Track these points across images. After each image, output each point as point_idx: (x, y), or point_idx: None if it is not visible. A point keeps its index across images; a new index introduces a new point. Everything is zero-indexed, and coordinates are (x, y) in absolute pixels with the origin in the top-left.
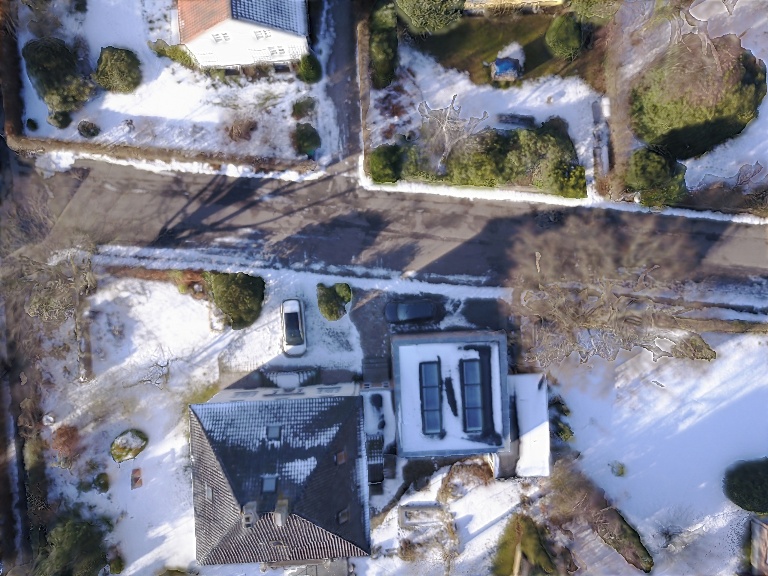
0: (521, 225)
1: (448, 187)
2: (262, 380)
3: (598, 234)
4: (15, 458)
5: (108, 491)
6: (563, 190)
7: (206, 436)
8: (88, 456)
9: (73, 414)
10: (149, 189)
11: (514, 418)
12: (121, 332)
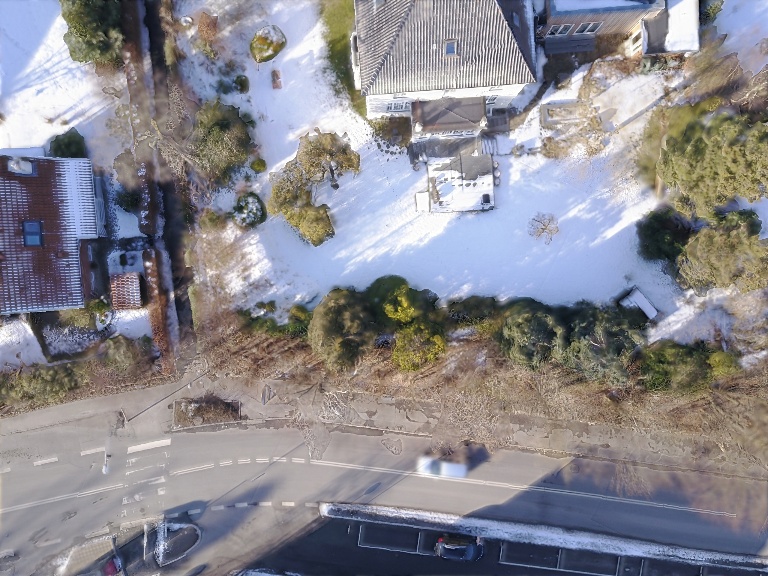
0: None
1: None
2: None
3: None
4: (151, 70)
5: (248, 93)
6: None
7: None
8: (227, 57)
9: None
10: None
11: None
12: None
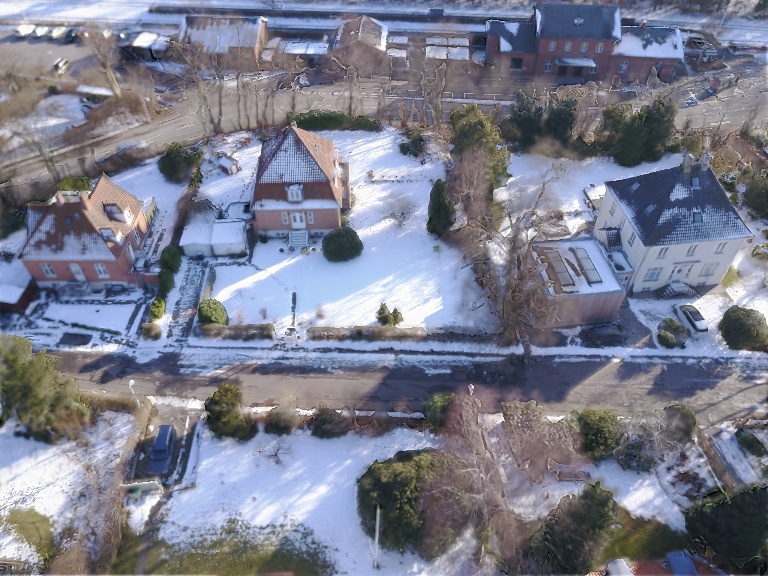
0: (539, 398)
1: None
2: (696, 290)
3: (472, 396)
4: None
5: (761, 232)
6: (524, 406)
7: None
8: None
9: None
10: None
11: (519, 267)
12: None
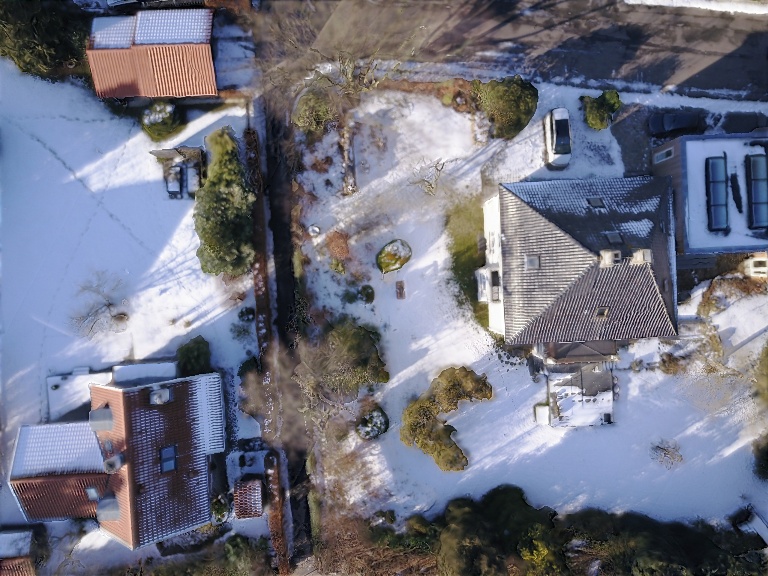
0: None
1: (709, 0)
2: None
3: None
4: (274, 273)
5: (372, 303)
6: None
7: (529, 205)
8: (353, 267)
9: (336, 226)
10: (411, 2)
11: None
12: (385, 144)
